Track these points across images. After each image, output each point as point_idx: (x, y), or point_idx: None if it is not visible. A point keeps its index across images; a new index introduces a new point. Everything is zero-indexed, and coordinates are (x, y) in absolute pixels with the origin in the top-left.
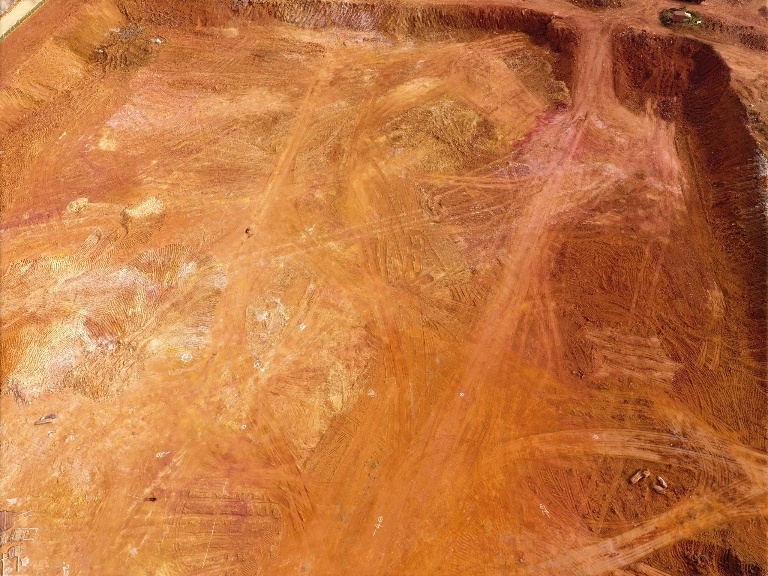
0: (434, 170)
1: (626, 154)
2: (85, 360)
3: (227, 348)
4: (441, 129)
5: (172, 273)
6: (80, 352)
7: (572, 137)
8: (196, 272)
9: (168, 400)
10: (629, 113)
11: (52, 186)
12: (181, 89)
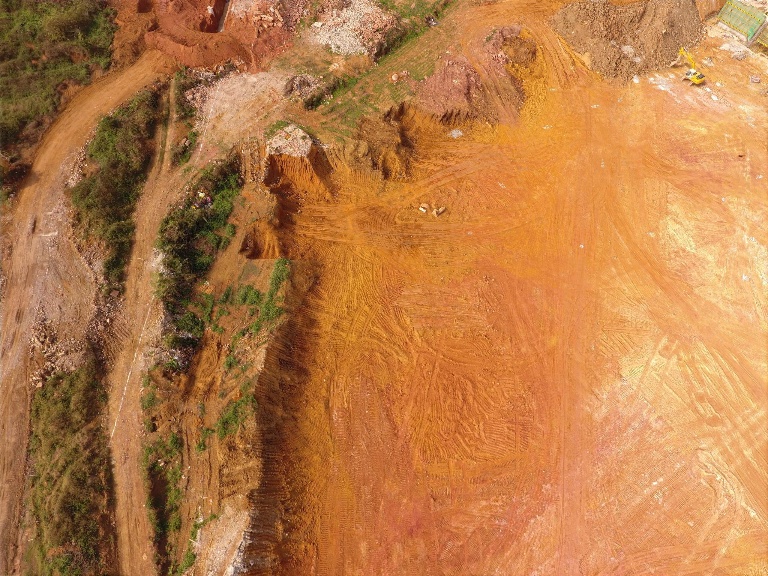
0: (764, 573)
1: None
2: None
3: None
4: None
5: None
6: None
7: None
8: None
9: None
10: None
11: None
12: None
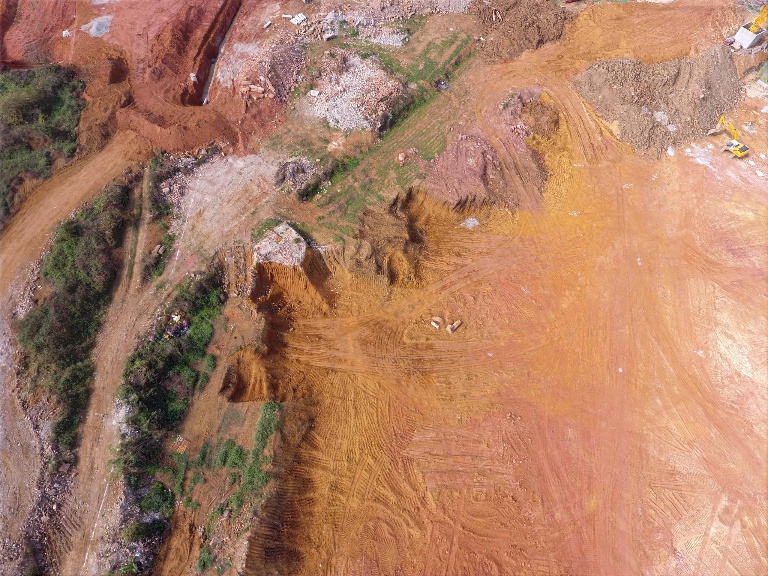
0: None
1: None
2: None
3: None
4: None
5: None
6: None
7: None
8: None
9: None
10: None
11: None
12: None
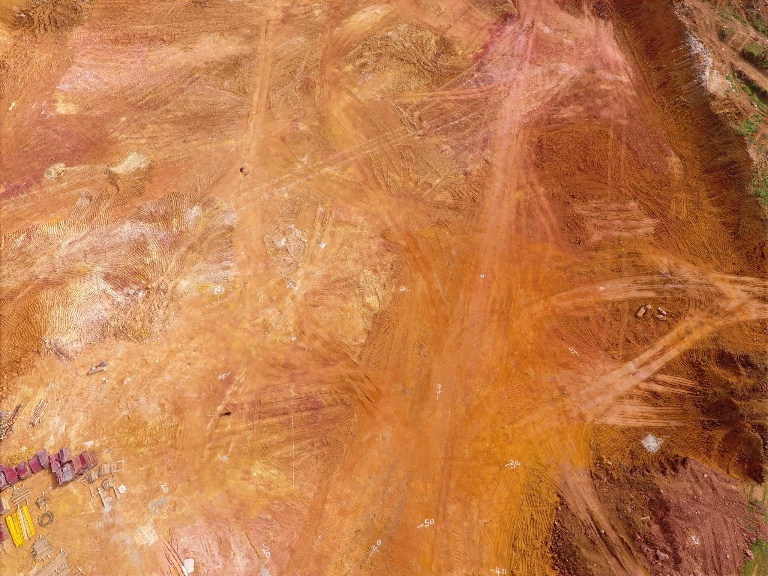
0: (407, 90)
1: (575, 53)
2: (117, 311)
3: (256, 276)
4: (403, 51)
5: (178, 219)
6: (109, 305)
7: (525, 44)
8: (203, 215)
9: (214, 330)
10: (570, 16)
11: (19, 157)
12: (127, 45)
